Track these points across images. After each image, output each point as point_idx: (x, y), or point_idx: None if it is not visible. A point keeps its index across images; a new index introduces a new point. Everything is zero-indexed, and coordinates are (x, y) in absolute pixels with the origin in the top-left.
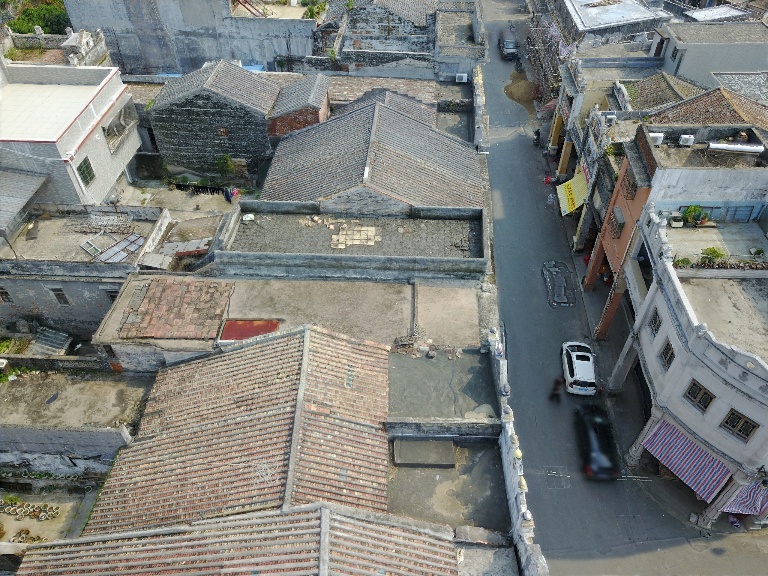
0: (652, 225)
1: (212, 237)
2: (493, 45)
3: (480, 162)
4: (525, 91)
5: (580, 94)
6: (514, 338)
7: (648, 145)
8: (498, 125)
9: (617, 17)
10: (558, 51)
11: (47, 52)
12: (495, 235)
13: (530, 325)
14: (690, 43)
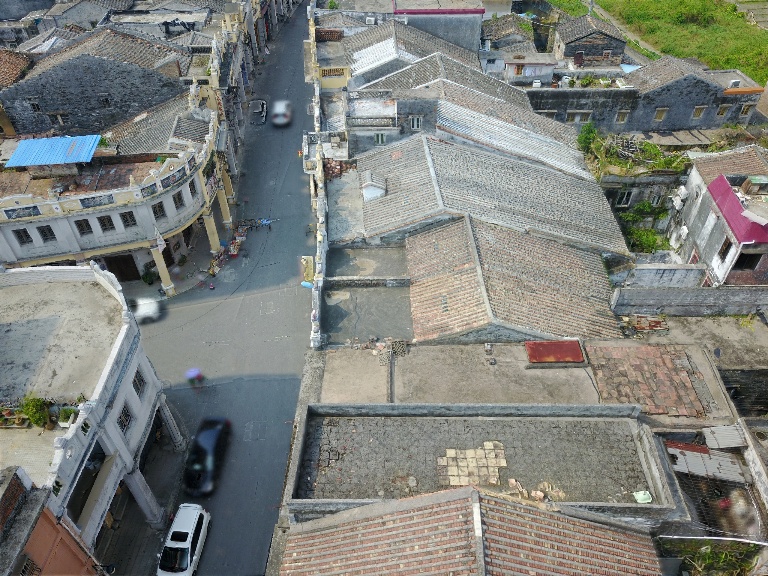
0: None
1: (676, 469)
2: None
3: None
4: None
5: None
6: None
7: None
8: None
9: None
10: None
11: None
12: None
13: None
14: None
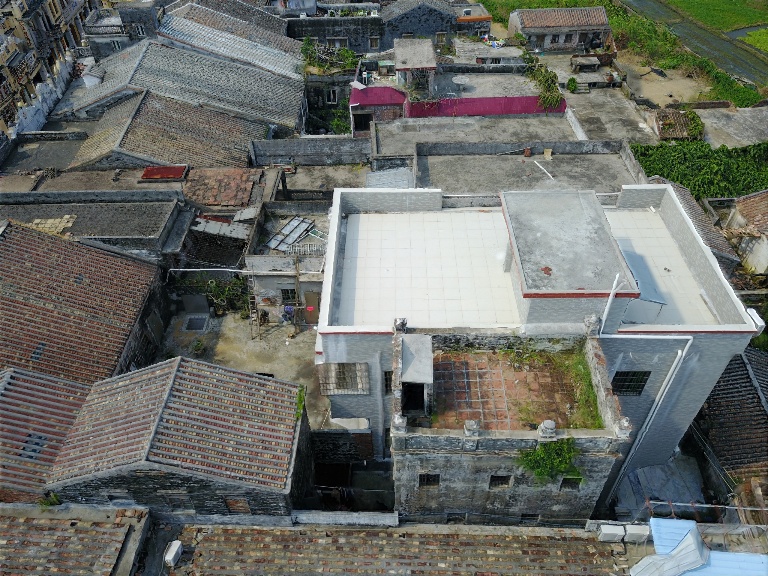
0: None
1: (193, 228)
2: None
3: None
4: None
5: None
6: None
7: None
8: None
9: None
10: None
11: (522, 429)
12: None
13: None
14: None
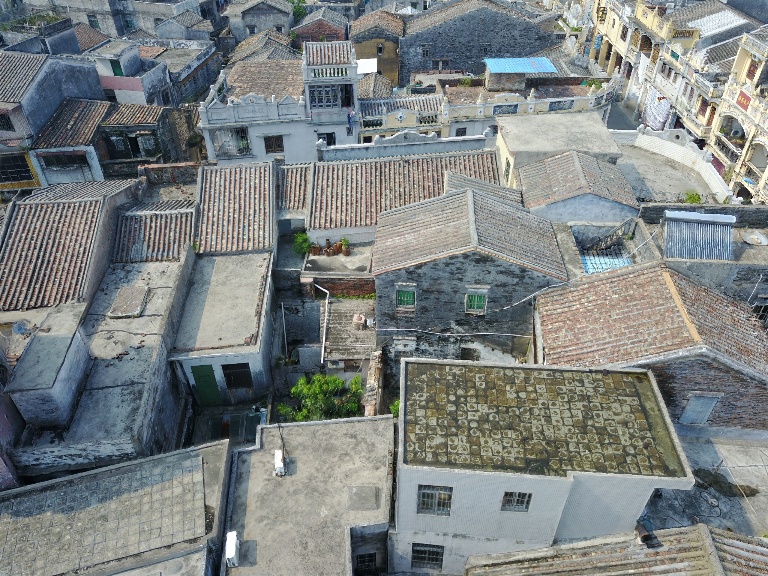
0: None
1: None
2: None
3: None
4: None
5: None
6: None
7: None
8: None
9: None
10: None
11: None
12: None
13: None
14: None
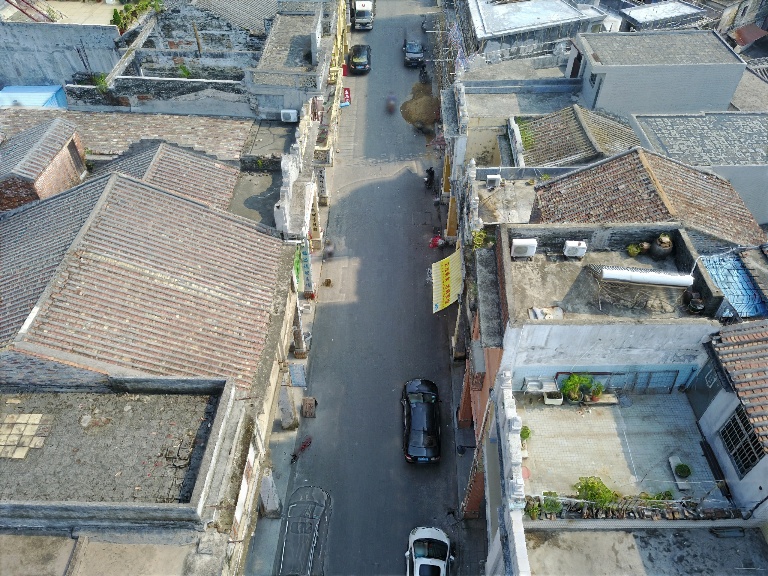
0: (505, 414)
1: None
2: (398, 47)
3: (283, 259)
4: (424, 111)
5: (461, 136)
6: (344, 516)
7: (502, 270)
8: (384, 159)
9: (530, 19)
10: (454, 64)
11: None
12: (349, 332)
13: (372, 491)
14: (610, 65)
